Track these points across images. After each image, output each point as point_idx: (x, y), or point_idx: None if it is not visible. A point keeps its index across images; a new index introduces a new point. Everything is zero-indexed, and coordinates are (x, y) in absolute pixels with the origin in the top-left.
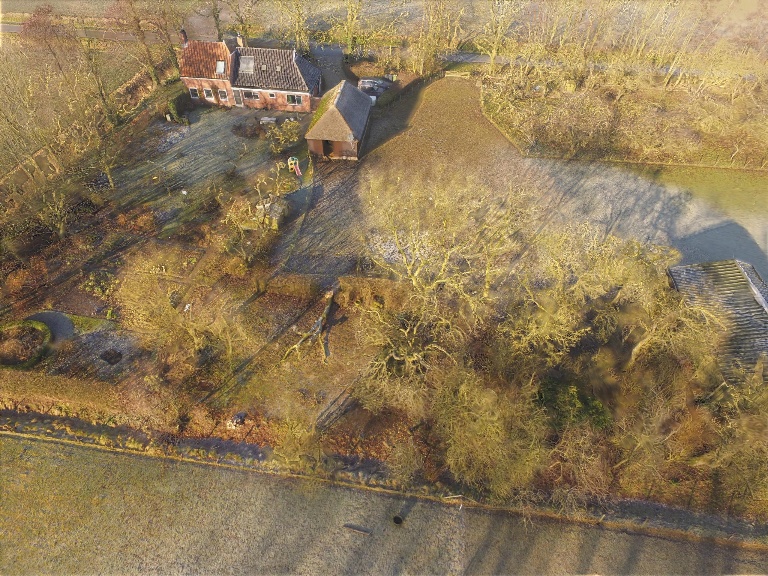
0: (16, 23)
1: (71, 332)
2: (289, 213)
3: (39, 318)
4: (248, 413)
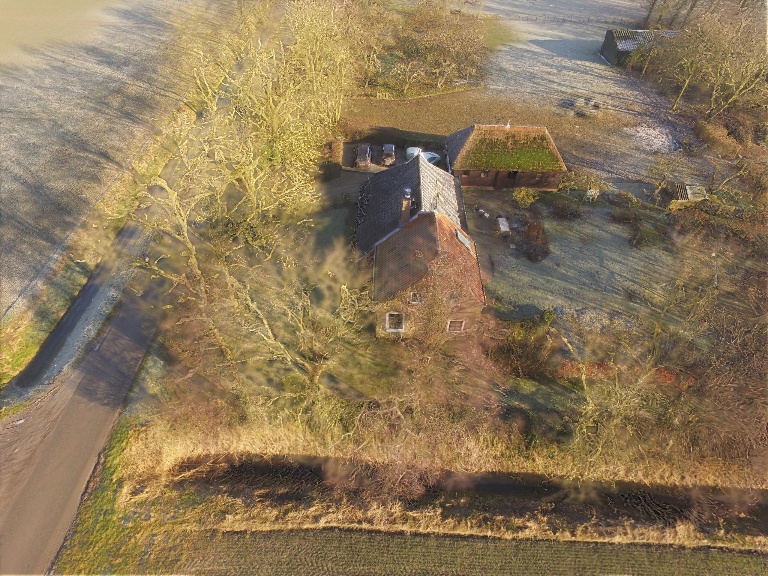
0: None
1: None
2: None
3: None
4: None
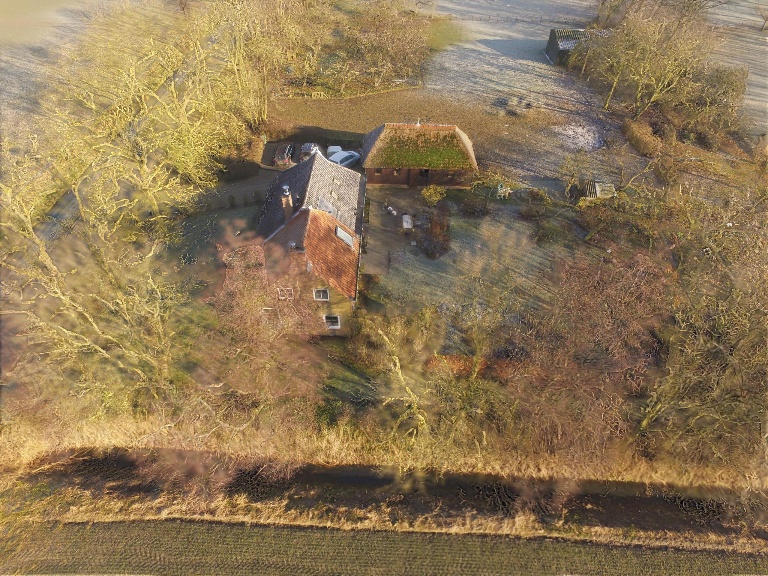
0: None
1: None
2: None
3: None
4: (767, 183)
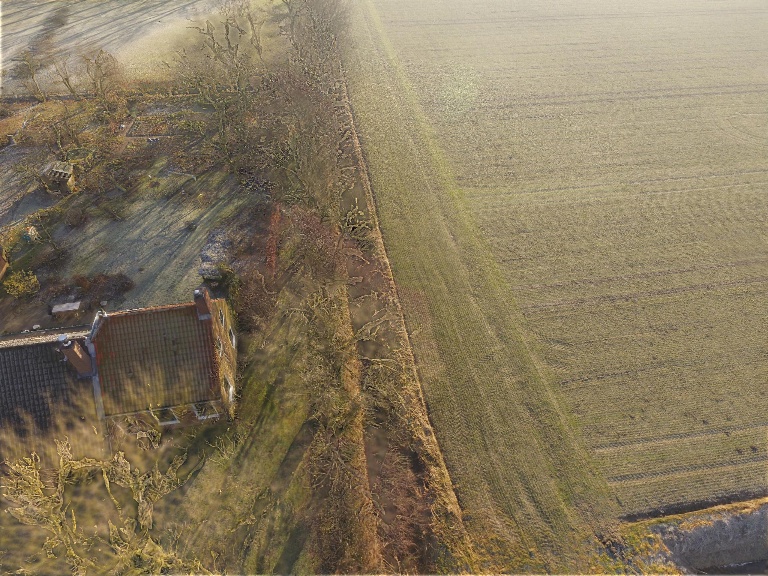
0: None
1: None
2: (44, 191)
3: None
4: None
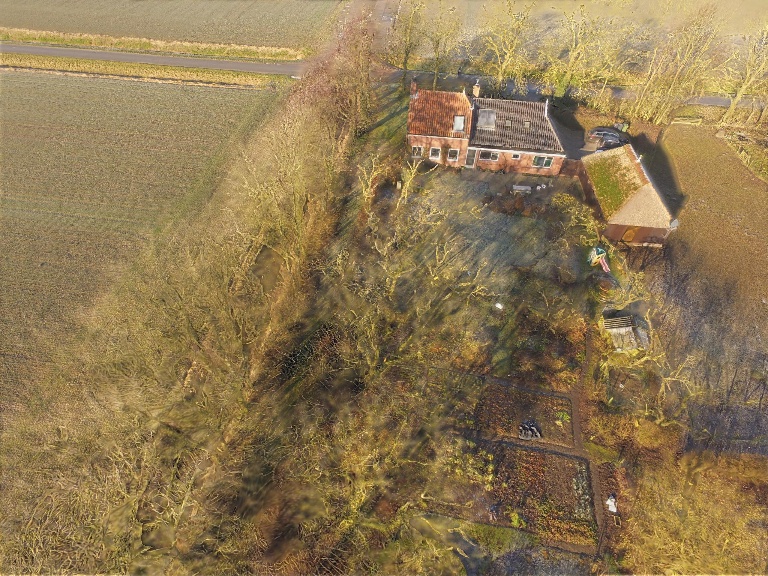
0: (140, 51)
1: (479, 554)
2: None
3: (420, 527)
4: None
